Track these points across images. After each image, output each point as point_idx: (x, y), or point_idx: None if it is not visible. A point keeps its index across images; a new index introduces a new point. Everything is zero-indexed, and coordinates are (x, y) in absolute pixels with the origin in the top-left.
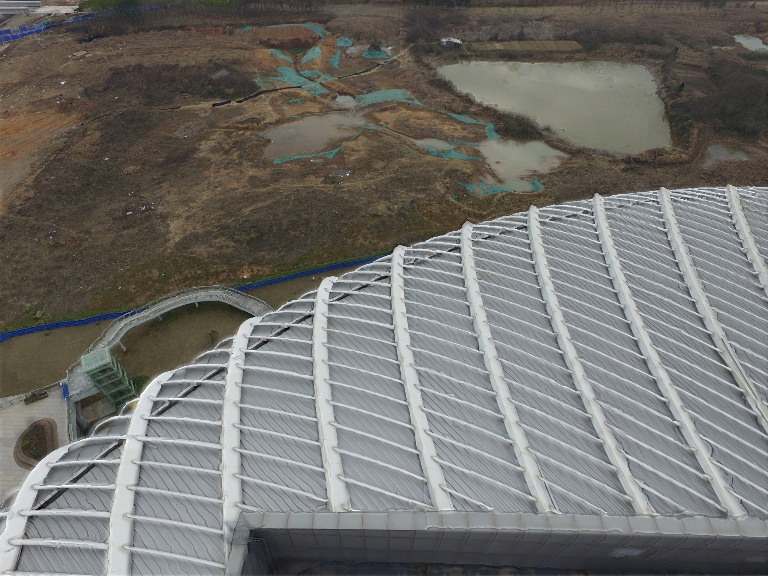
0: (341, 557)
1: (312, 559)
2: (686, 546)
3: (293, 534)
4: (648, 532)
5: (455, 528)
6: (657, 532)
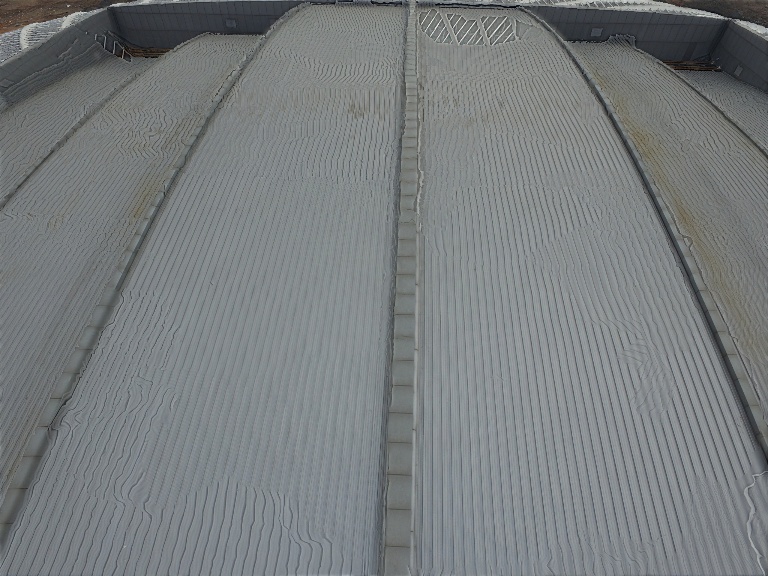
0: (147, 42)
1: (136, 41)
2: (240, 12)
3: (123, 13)
4: (223, 1)
5: (170, 5)
6: (226, 1)
